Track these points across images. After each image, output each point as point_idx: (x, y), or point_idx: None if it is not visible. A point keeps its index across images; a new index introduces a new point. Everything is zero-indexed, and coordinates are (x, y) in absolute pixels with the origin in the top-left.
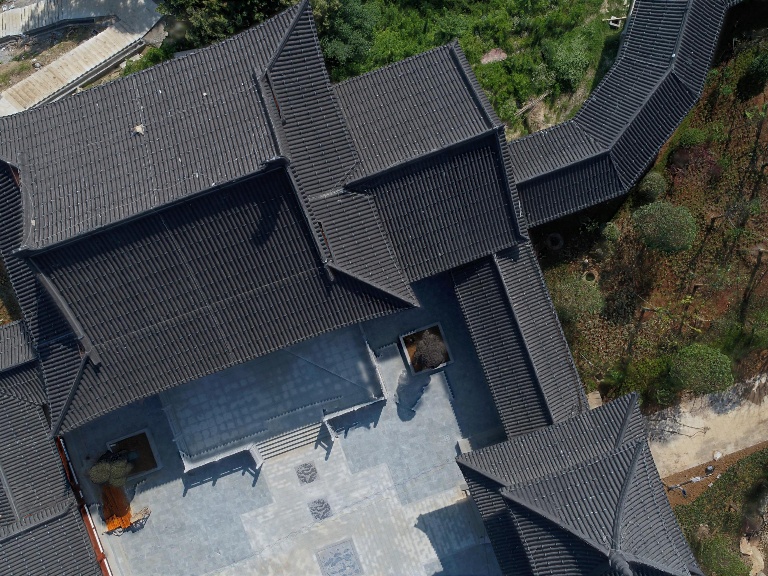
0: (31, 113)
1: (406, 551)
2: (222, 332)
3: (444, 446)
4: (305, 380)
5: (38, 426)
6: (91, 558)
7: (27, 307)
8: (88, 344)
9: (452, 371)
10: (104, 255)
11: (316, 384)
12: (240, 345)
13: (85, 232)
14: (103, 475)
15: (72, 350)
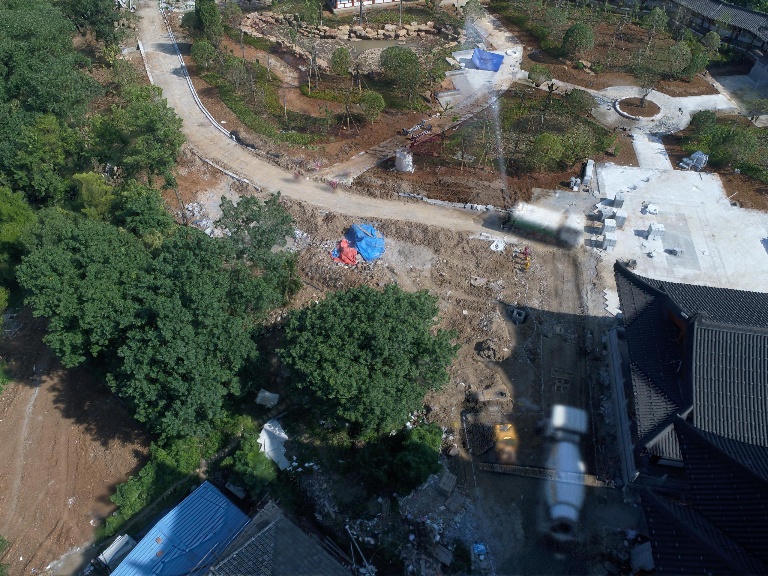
0: None
1: None
2: None
3: None
4: None
5: None
6: None
7: None
8: None
9: None
10: None
11: None
12: None
13: None
14: None
15: None
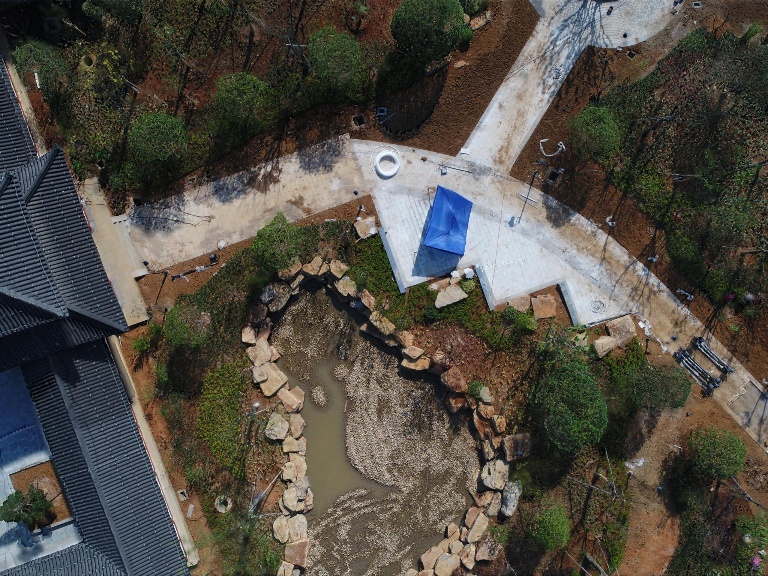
0: None
1: None
2: None
3: None
4: None
5: None
6: None
7: None
8: None
9: None
10: None
11: None
12: None
13: None
14: None
15: None
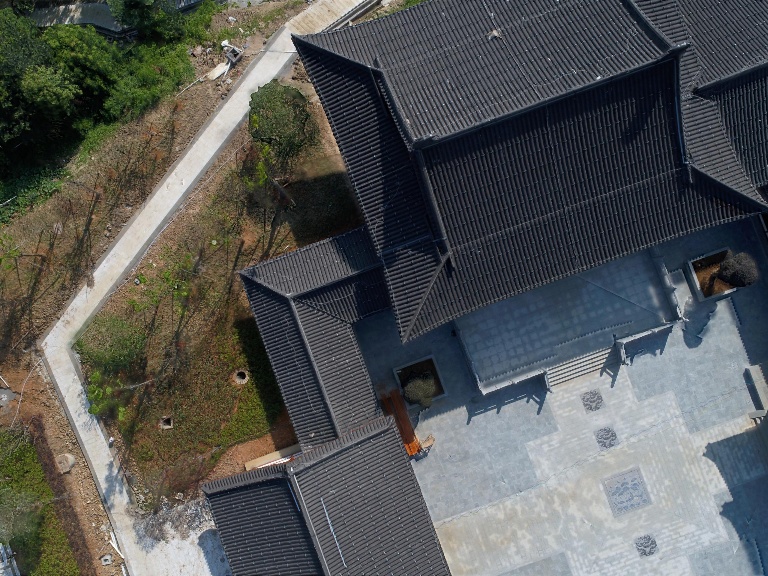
0: (375, 23)
1: (695, 481)
2: (572, 237)
3: (732, 373)
4: (595, 305)
5: (349, 344)
6: (411, 475)
7: (372, 214)
8: (448, 246)
9: (739, 297)
10: (483, 151)
11: (606, 309)
12: (587, 251)
13: (479, 123)
14: (419, 392)
15: (424, 255)
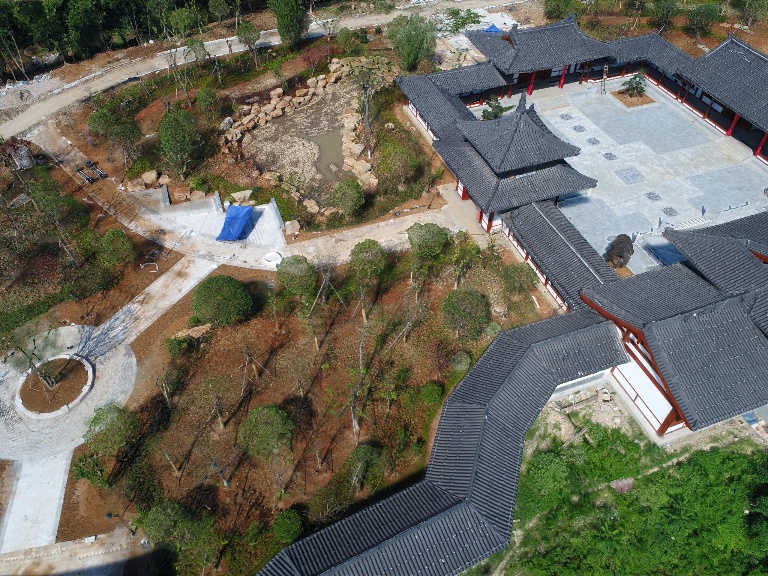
0: None
1: None
2: None
3: (581, 224)
4: None
5: None
6: None
7: None
8: None
9: None
10: None
11: None
12: None
13: None
14: None
15: None
